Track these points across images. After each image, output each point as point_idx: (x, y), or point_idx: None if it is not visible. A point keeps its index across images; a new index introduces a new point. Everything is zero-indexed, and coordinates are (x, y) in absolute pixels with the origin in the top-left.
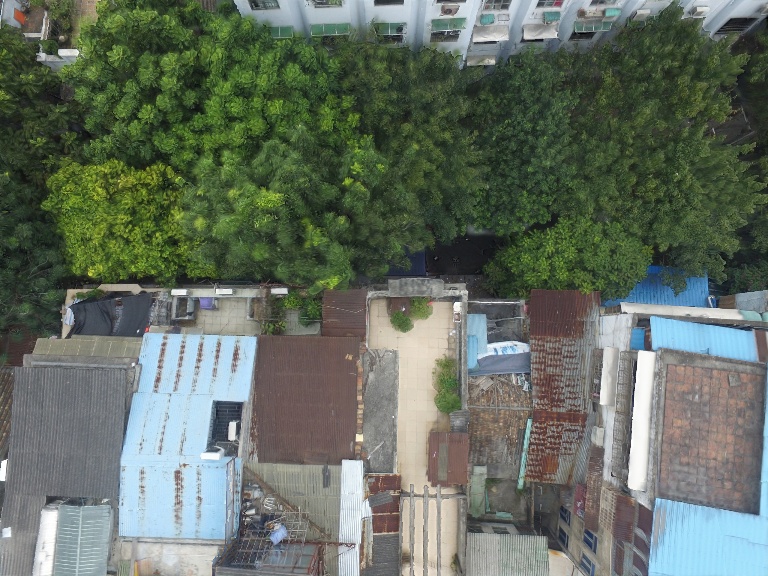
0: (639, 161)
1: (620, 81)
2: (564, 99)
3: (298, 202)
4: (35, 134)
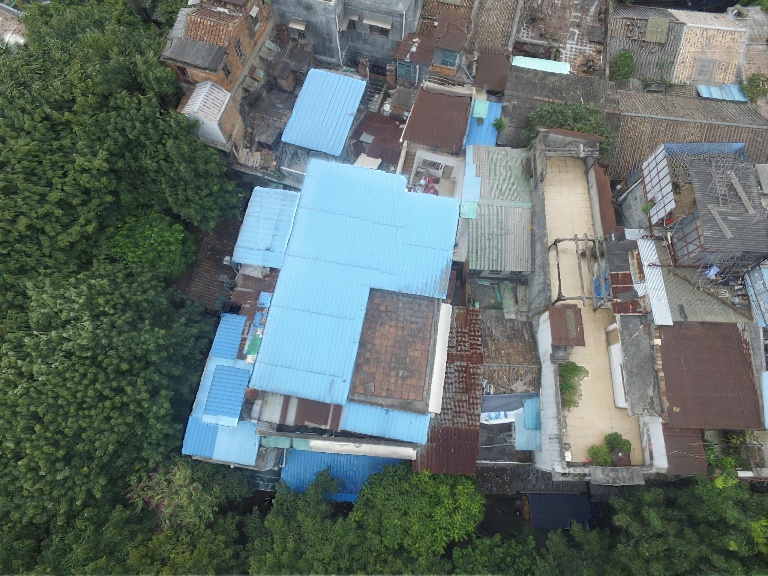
0: None
1: None
2: None
3: None
4: None
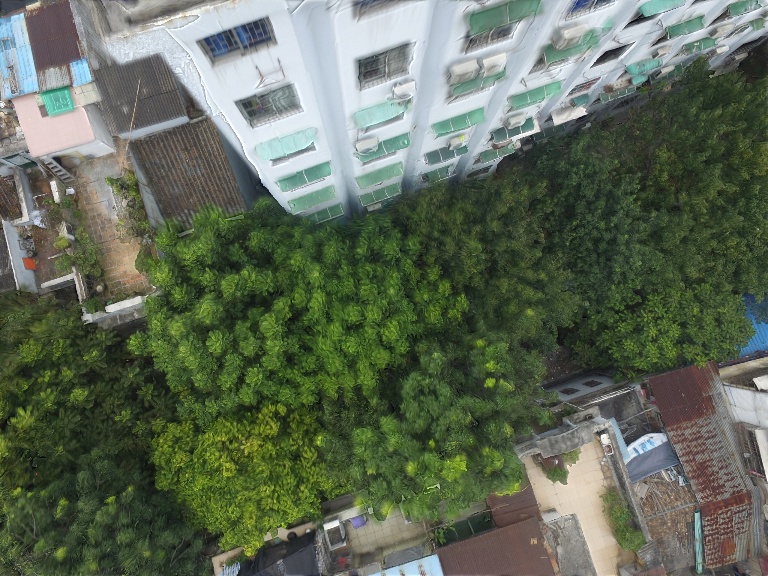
0: None
1: None
2: (626, 186)
3: None
4: (117, 408)
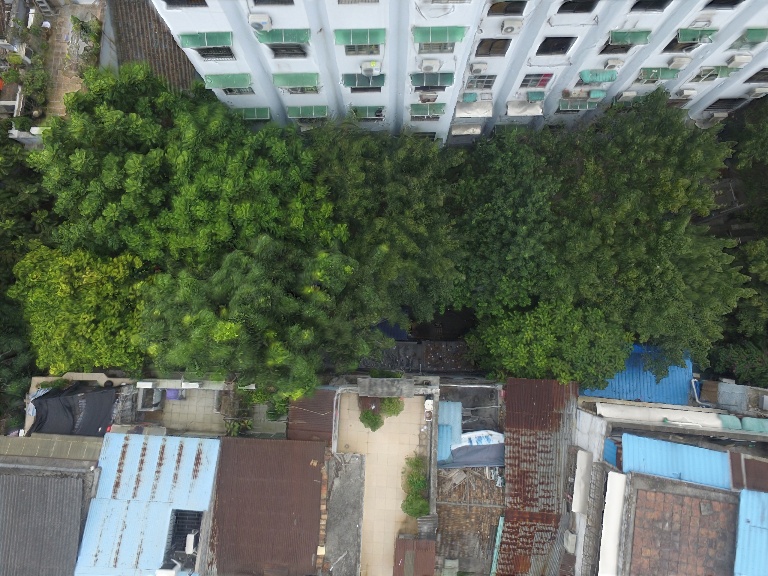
0: (621, 249)
1: (603, 167)
2: (545, 185)
3: (259, 318)
4: (4, 216)
